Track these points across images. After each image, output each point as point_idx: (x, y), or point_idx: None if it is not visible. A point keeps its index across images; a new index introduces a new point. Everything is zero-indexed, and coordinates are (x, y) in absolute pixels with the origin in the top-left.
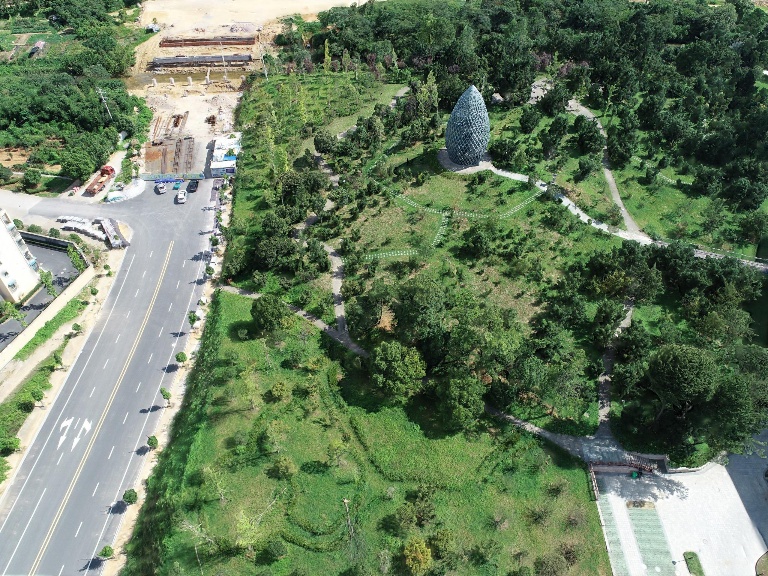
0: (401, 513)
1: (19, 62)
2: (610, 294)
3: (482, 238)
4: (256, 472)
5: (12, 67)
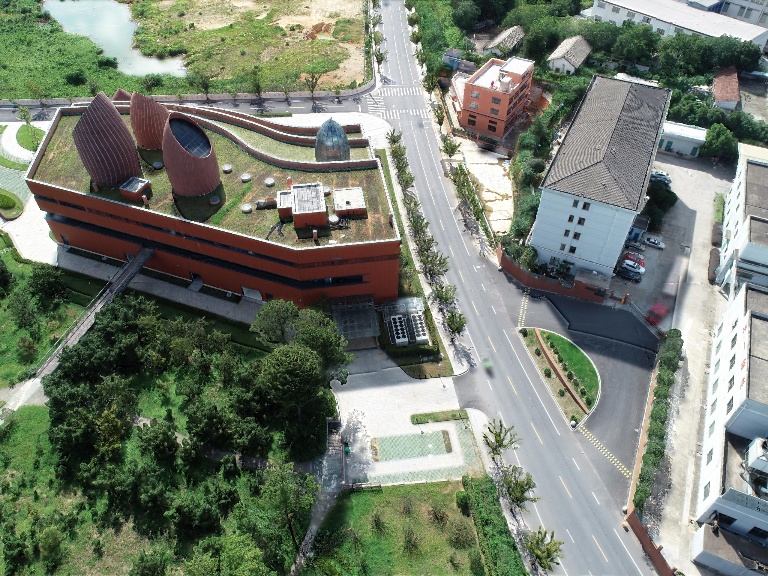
0: None
1: None
2: (118, 436)
3: None
4: None
5: None
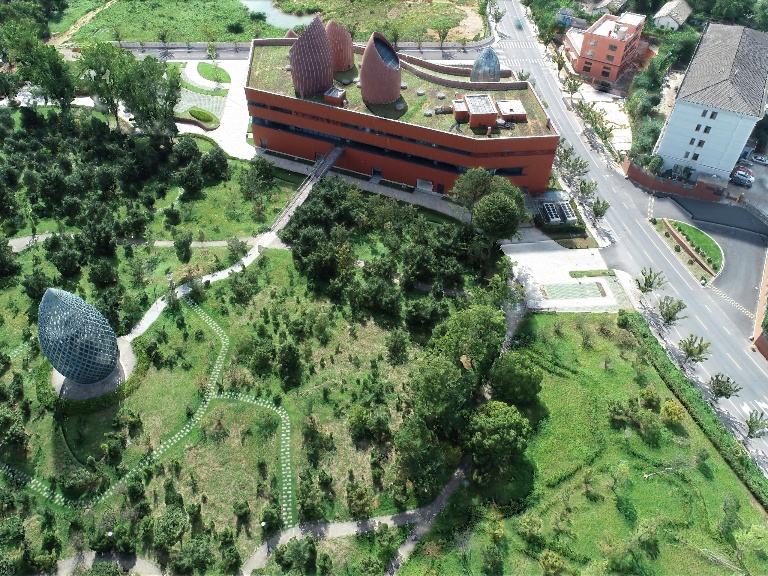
0: (651, 420)
1: None
2: None
3: (292, 346)
4: (660, 568)
5: None
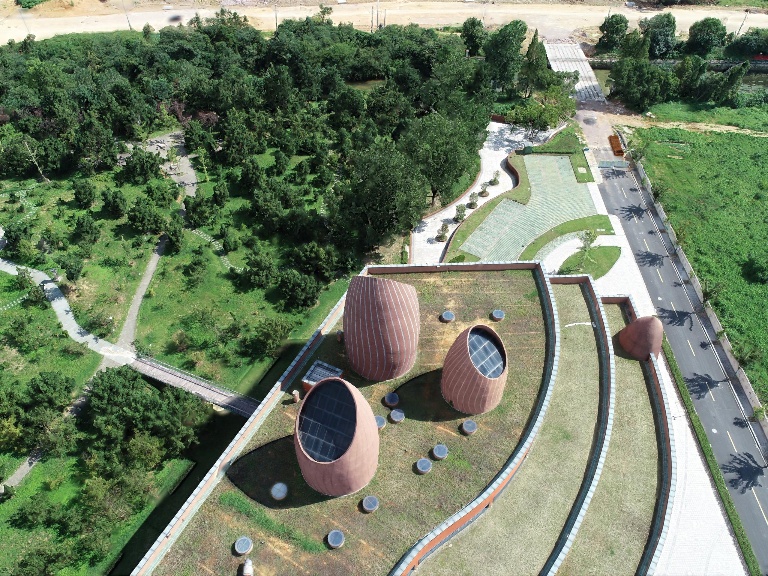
0: None
1: None
2: None
3: None
4: None
5: None
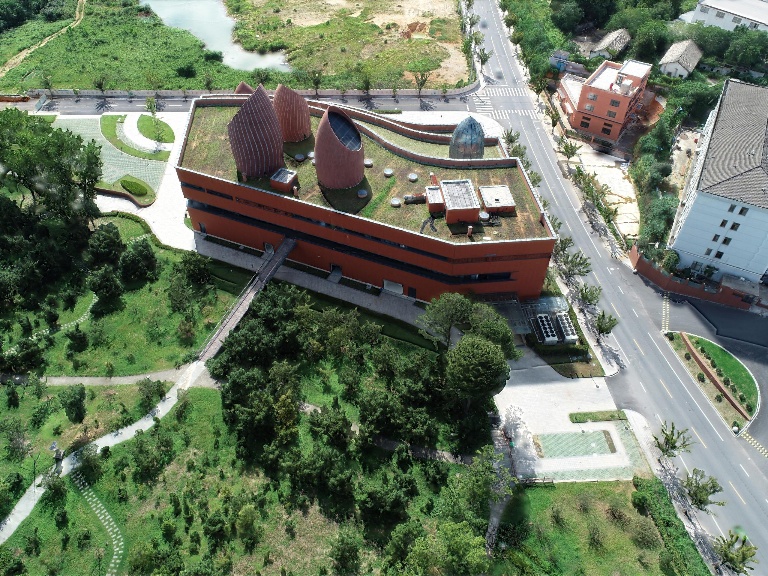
0: None
1: None
2: None
3: (200, 571)
4: None
5: None
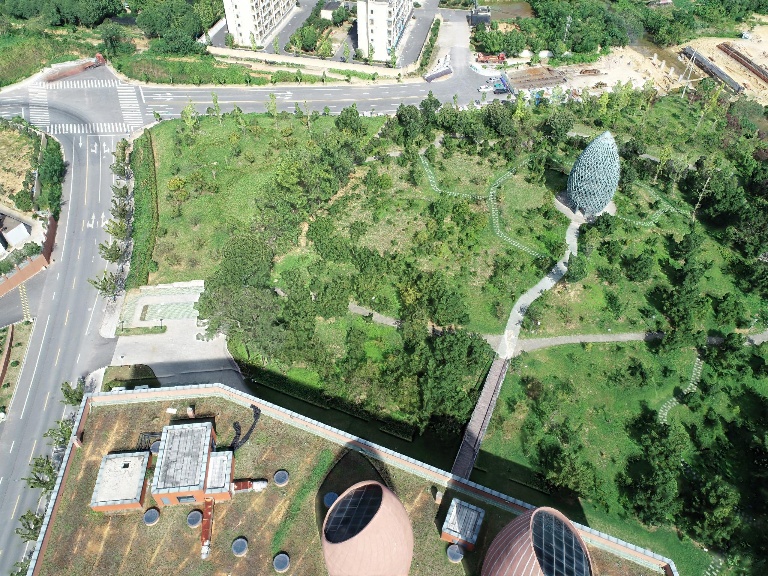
0: None
1: (637, 3)
2: None
3: None
4: None
5: (630, 3)
